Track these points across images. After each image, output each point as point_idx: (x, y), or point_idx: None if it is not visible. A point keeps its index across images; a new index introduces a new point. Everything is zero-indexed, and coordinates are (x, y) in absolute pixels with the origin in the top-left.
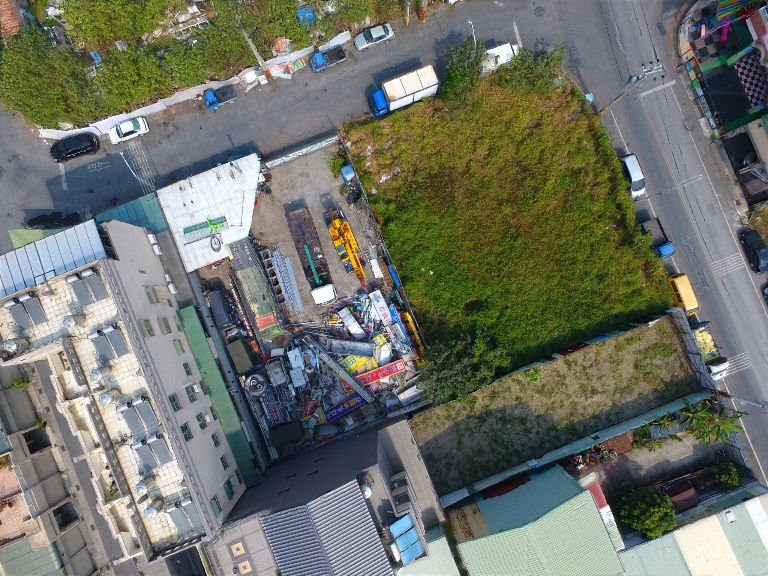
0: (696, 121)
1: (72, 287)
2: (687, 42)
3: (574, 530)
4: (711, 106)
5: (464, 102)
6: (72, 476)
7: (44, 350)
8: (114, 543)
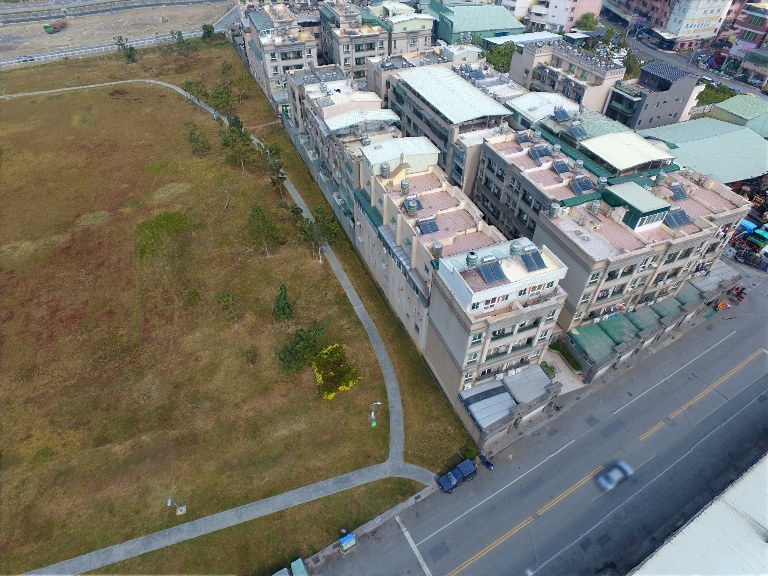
0: (721, 77)
1: (550, 44)
2: (703, 64)
3: (759, 99)
4: (724, 72)
5: (636, 63)
6: None
7: (548, 49)
8: None
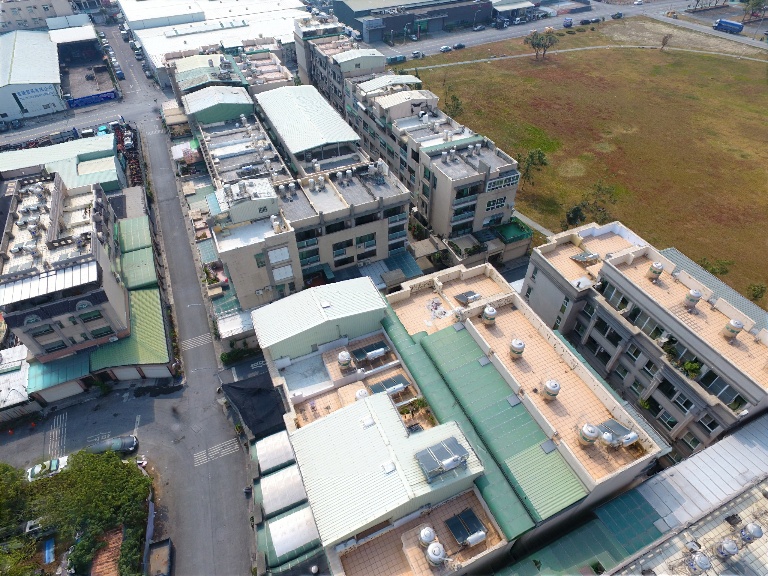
0: None
1: None
2: None
3: None
4: None
5: None
6: (195, 249)
7: None
8: (178, 224)
